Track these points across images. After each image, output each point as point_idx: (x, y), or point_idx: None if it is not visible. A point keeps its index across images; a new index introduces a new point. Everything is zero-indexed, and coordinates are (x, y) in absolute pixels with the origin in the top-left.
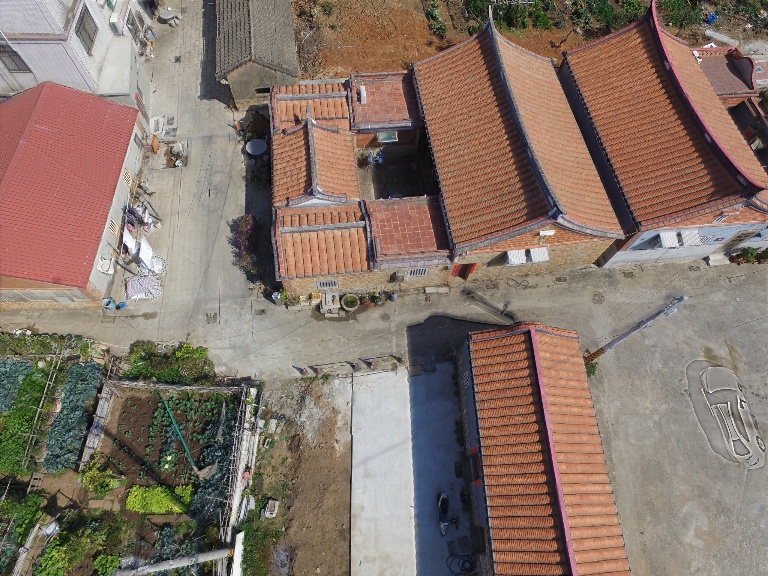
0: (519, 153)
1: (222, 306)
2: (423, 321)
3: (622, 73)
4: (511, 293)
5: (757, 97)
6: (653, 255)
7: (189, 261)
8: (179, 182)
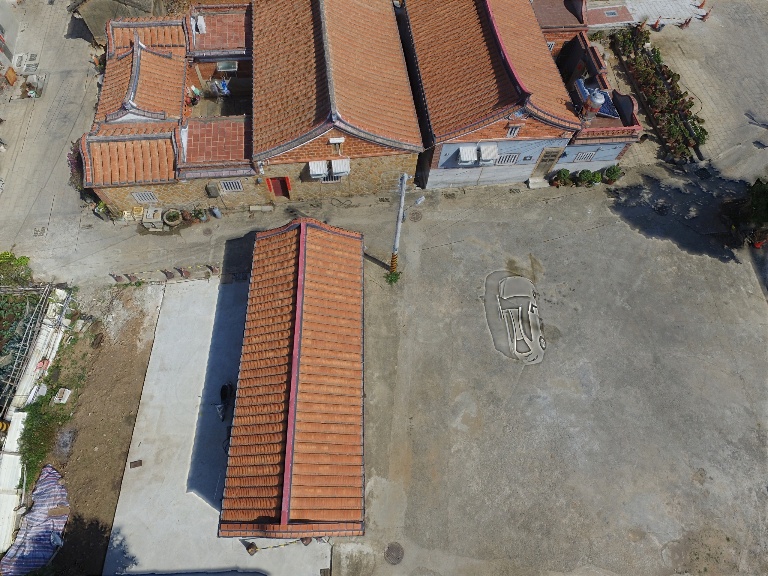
0: (321, 68)
1: (51, 221)
2: (243, 236)
3: (446, 3)
4: (333, 211)
5: (609, 39)
6: (470, 176)
7: (27, 181)
8: (30, 111)
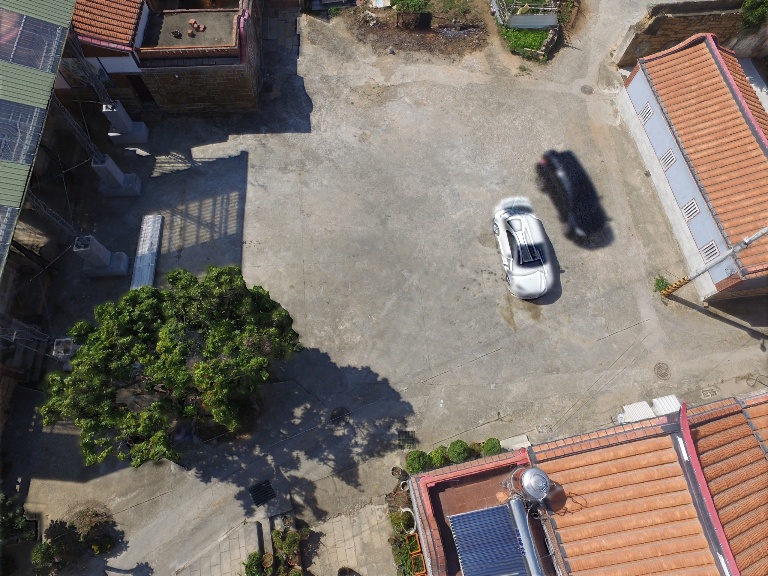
0: None
1: None
2: None
3: None
4: (763, 367)
5: None
6: None
7: None
8: None
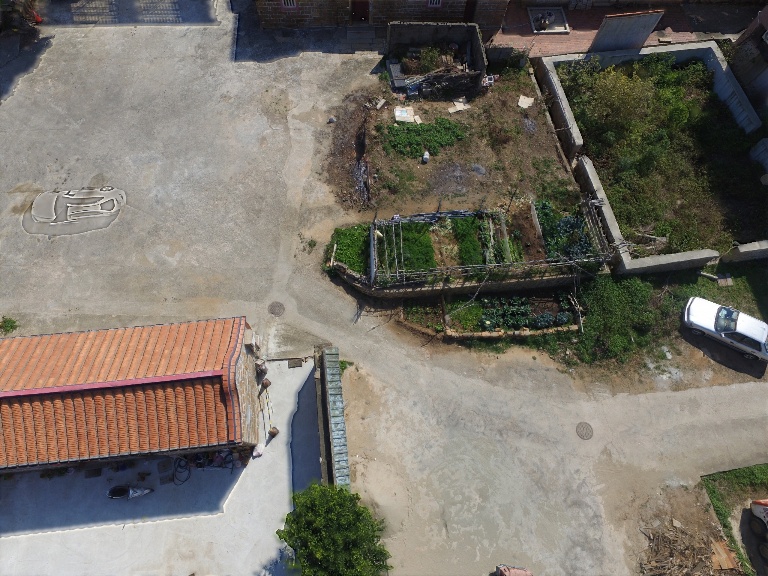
0: None
1: None
2: None
3: None
4: None
5: None
6: None
7: None
8: None
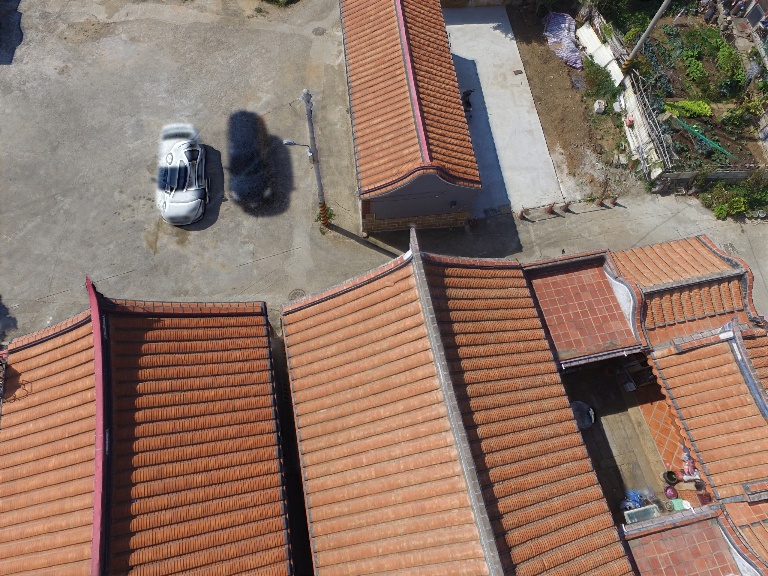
0: (458, 388)
1: None
2: None
3: None
4: None
5: None
6: None
7: None
8: None
